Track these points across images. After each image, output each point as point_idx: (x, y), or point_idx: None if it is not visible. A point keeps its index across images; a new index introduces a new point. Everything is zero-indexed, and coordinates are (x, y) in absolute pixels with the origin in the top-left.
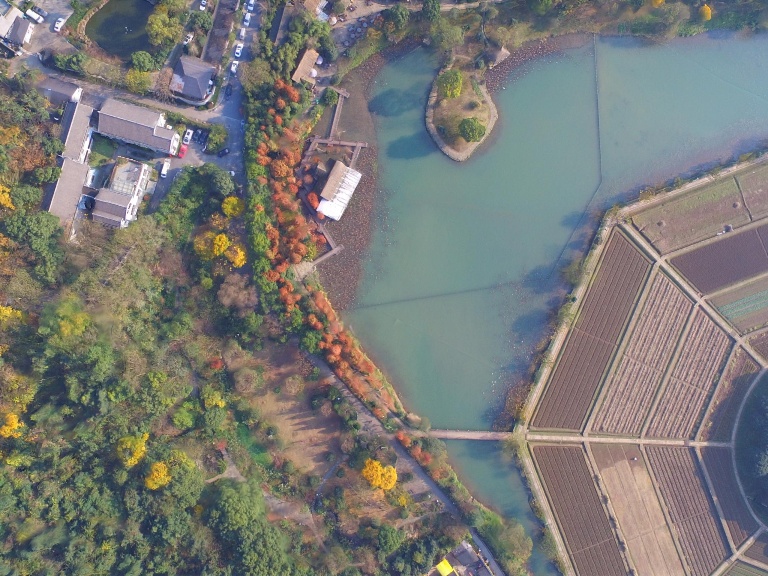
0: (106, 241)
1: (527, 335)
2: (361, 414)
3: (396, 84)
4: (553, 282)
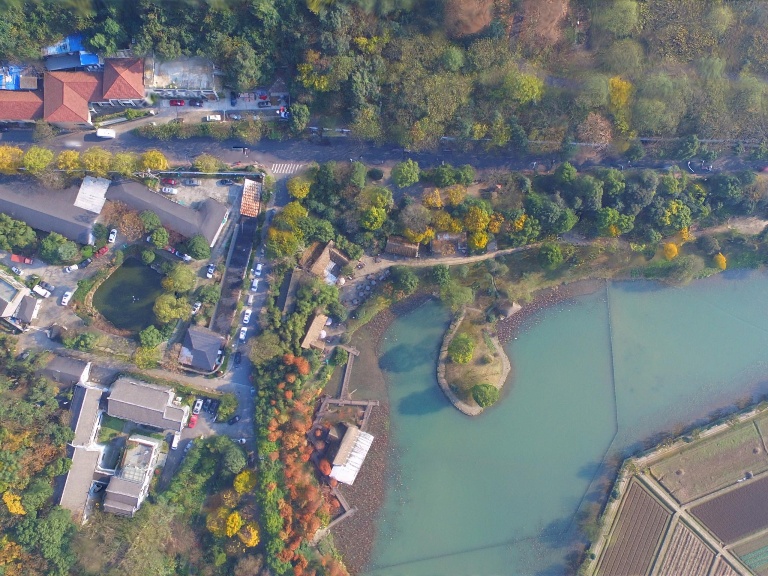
0: (118, 520)
1: None
2: None
3: (406, 338)
4: (571, 536)
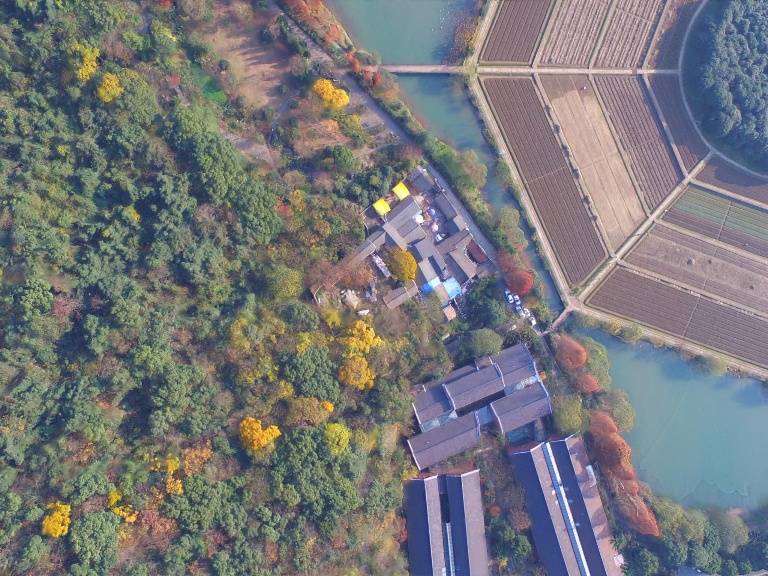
0: None
1: None
2: (312, 50)
3: None
4: None
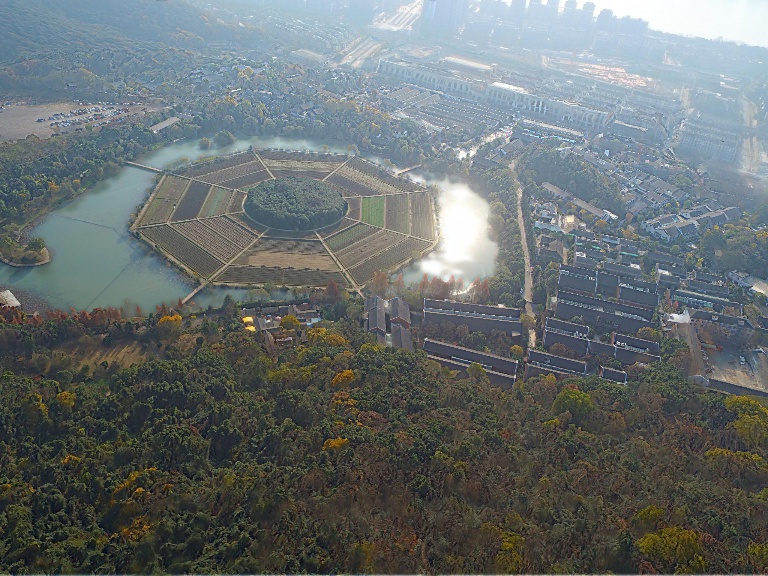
0: None
1: (159, 267)
2: None
3: None
4: (143, 253)
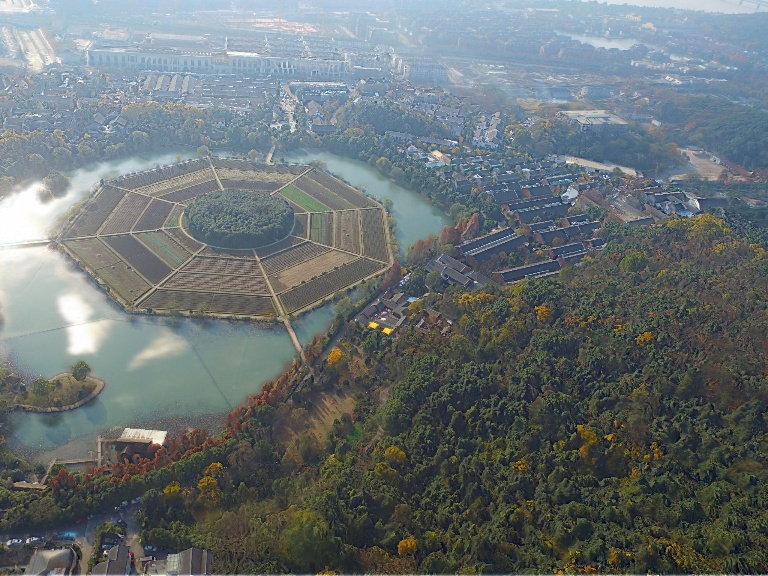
0: None
1: (221, 329)
2: None
3: (41, 435)
4: (183, 325)
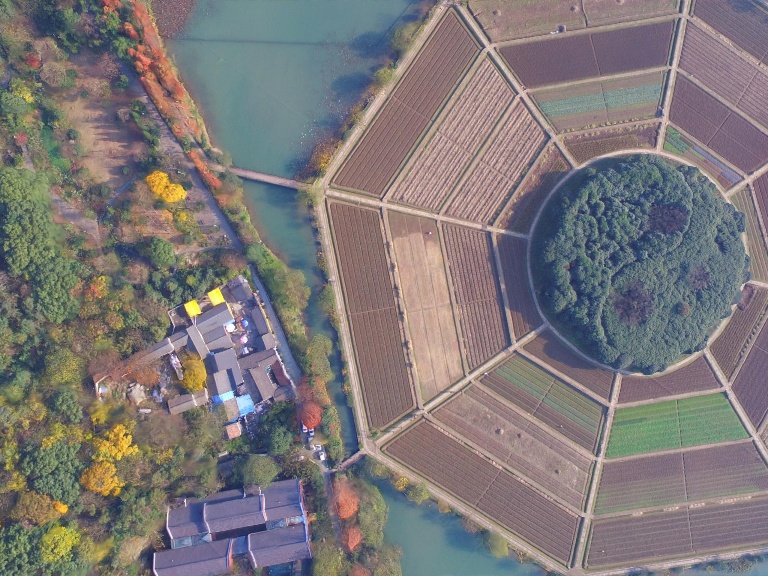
0: None
1: (345, 95)
2: (166, 138)
3: None
4: (380, 50)
